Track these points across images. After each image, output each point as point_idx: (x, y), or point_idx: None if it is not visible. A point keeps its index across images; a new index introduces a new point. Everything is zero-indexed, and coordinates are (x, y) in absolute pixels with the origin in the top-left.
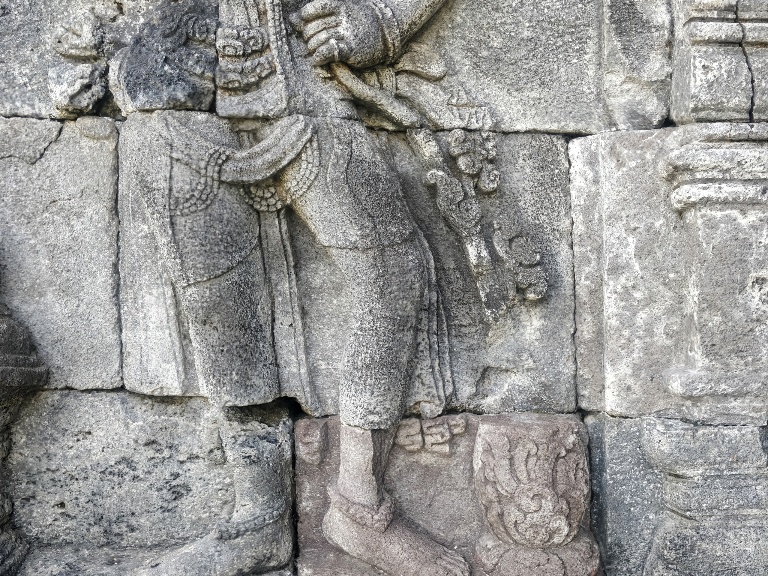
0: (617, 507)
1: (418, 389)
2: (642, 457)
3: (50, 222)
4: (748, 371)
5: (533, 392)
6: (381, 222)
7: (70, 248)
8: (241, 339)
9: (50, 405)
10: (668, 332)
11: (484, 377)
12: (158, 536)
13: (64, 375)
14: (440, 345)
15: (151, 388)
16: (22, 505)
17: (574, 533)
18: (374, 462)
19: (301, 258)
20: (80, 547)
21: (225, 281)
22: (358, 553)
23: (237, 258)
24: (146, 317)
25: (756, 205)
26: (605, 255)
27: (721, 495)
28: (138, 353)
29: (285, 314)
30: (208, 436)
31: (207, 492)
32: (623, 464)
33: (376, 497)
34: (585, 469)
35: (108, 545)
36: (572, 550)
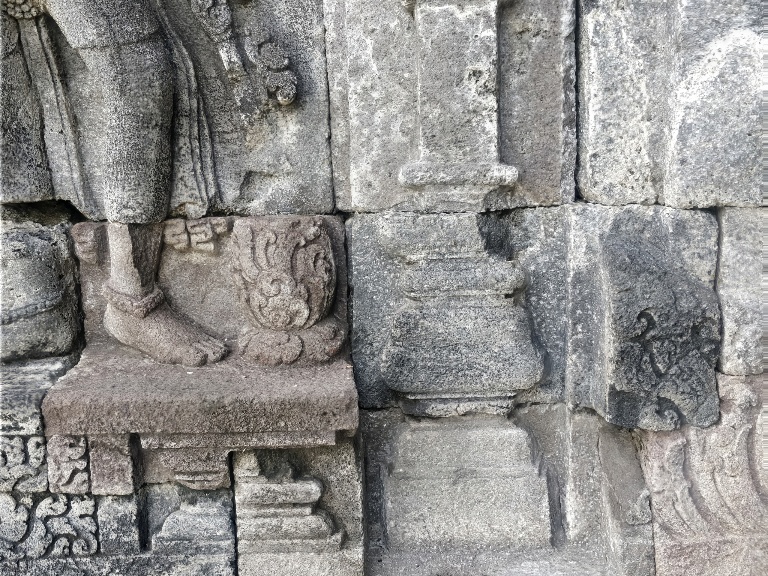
0: (361, 296)
1: (181, 191)
2: (383, 249)
3: None
4: (466, 161)
5: (294, 195)
6: (116, 21)
7: None
8: (1, 139)
9: None
10: (404, 130)
11: (248, 181)
12: None
13: None
14: (202, 150)
15: None
16: None
17: (316, 317)
18: (136, 256)
19: (70, 69)
20: None
21: None
22: (125, 339)
23: None
24: None
25: None
26: (347, 58)
27: (441, 277)
28: None
29: (54, 121)
30: None
31: None
32: (366, 256)
33: (141, 289)
34: (329, 260)
35: None
36: (314, 332)
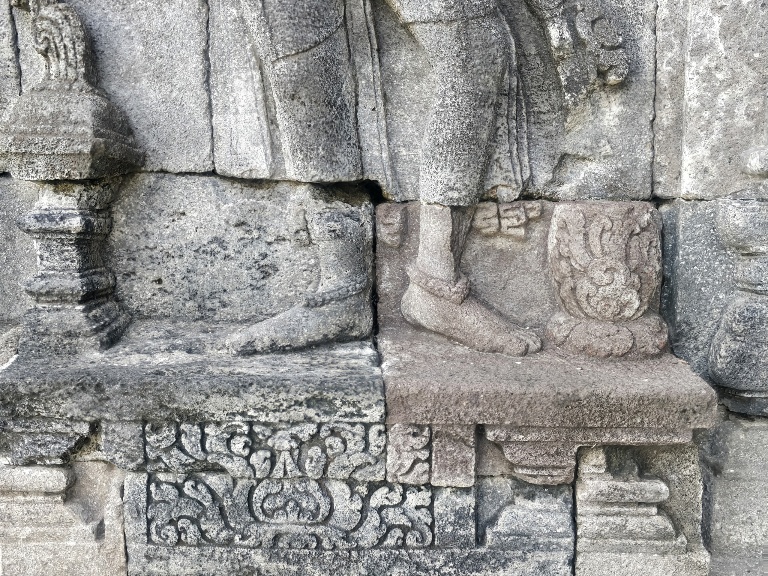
0: (688, 287)
1: (496, 173)
2: (715, 238)
3: (143, 9)
4: None
5: (609, 179)
6: None
7: (163, 34)
8: (327, 115)
9: (147, 186)
10: (749, 113)
11: (561, 164)
12: (248, 312)
13: (159, 158)
14: (519, 130)
15: (241, 170)
16: (124, 280)
17: (644, 308)
18: (452, 239)
19: (384, 43)
20: (177, 320)
21: (312, 56)
22: (435, 325)
23: (324, 33)
24: (235, 101)
25: None
26: (689, 36)
27: None
28: (228, 137)
29: (368, 97)
30: (294, 217)
31: (293, 272)
32: (696, 245)
33: (453, 273)
34: (658, 249)
35: (202, 319)
36: (642, 324)
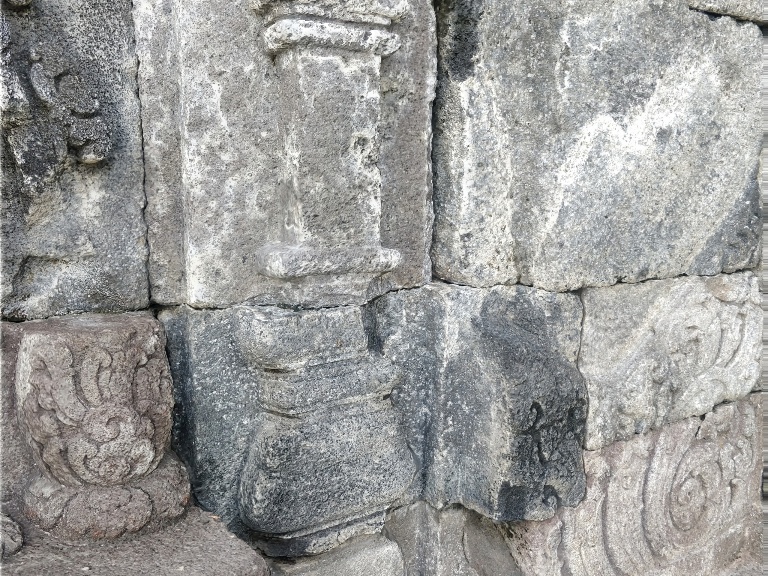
0: (207, 417)
1: None
2: (234, 354)
3: None
4: (350, 244)
5: (93, 286)
6: None
7: None
8: None
9: None
10: (261, 203)
11: (23, 270)
12: None
13: None
14: None
15: None
16: None
17: (160, 457)
18: None
19: None
20: None
21: None
22: None
23: None
24: None
25: (357, 52)
26: (185, 105)
27: (325, 386)
28: None
29: None
30: None
31: None
32: (213, 365)
33: None
34: (169, 377)
35: None
36: (158, 478)
